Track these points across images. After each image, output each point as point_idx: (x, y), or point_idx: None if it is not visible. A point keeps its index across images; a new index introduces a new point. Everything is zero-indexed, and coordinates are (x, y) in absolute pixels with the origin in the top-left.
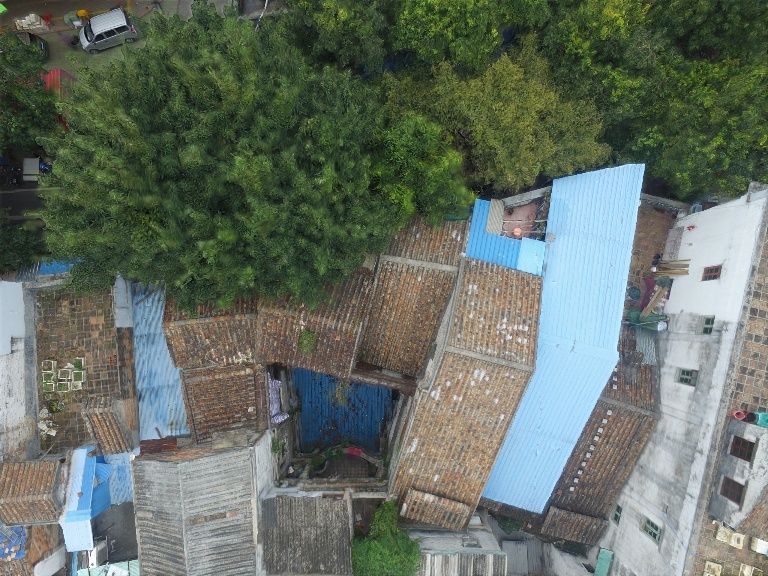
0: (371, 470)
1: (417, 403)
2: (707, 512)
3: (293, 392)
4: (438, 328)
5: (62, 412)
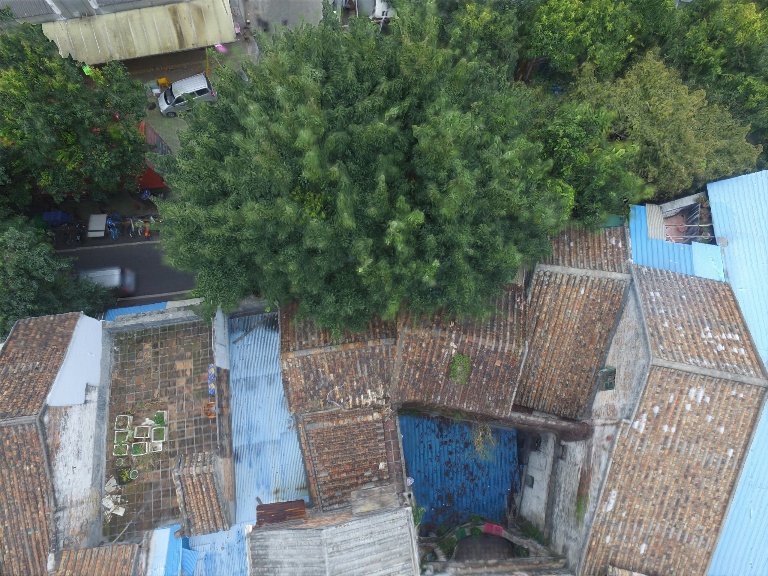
0: (520, 553)
1: (616, 439)
2: None
3: None
4: (606, 352)
5: (134, 483)
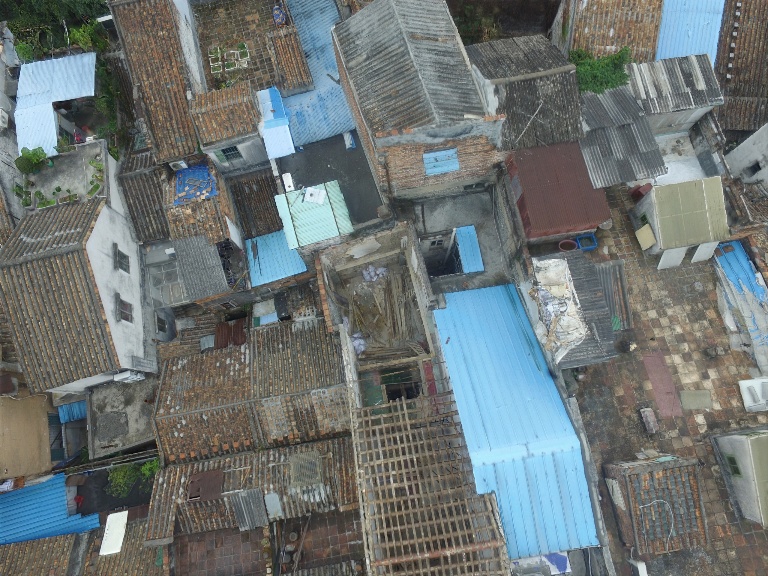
0: None
1: None
2: None
3: None
4: None
5: None
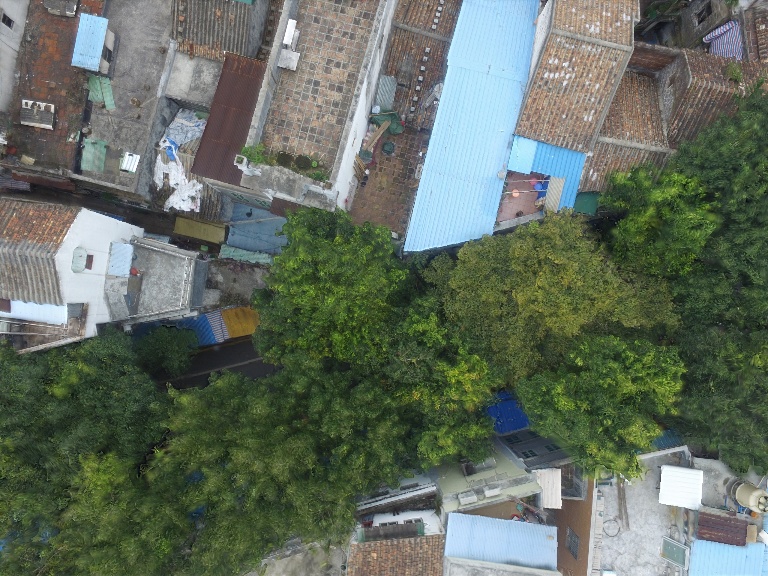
0: None
1: None
2: None
3: None
4: None
5: None
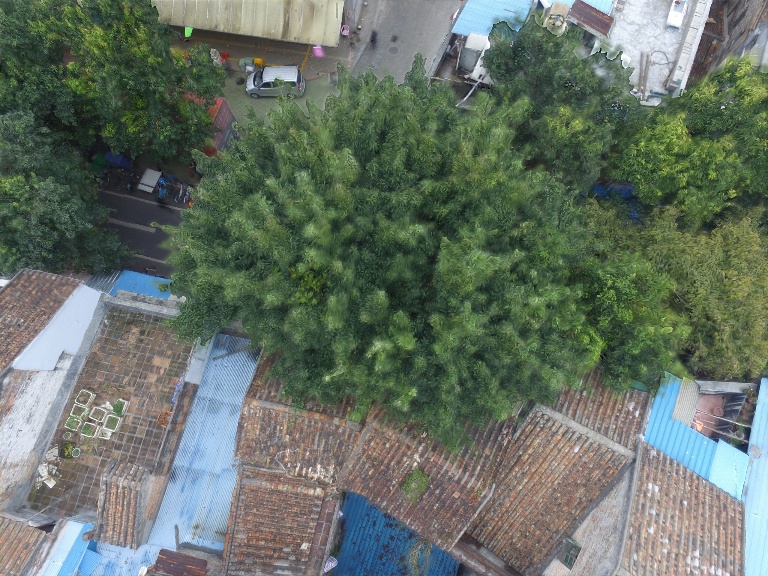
0: None
1: None
2: None
3: (339, 523)
4: (579, 521)
5: (73, 460)
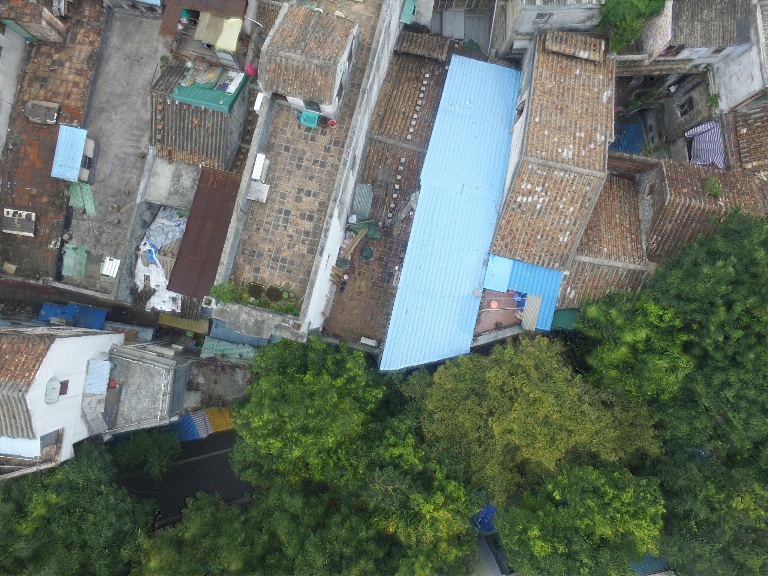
0: None
1: None
2: (360, 42)
3: None
4: None
5: None
